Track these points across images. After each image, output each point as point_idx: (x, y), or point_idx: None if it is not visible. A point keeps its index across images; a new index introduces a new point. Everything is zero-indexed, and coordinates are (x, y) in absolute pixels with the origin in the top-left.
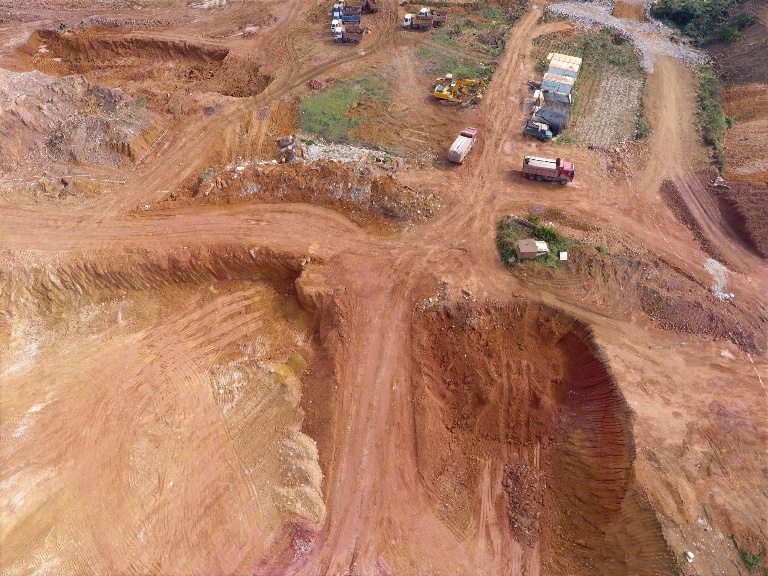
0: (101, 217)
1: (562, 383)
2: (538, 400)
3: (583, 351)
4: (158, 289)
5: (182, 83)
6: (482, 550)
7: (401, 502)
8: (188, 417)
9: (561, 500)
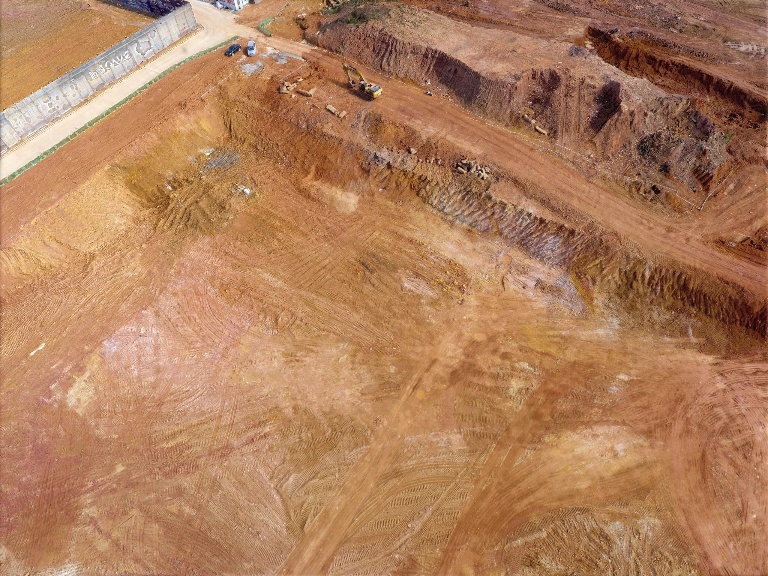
0: (688, 235)
1: None
2: None
3: None
4: (727, 324)
5: (721, 122)
6: None
7: None
8: (765, 462)
9: None
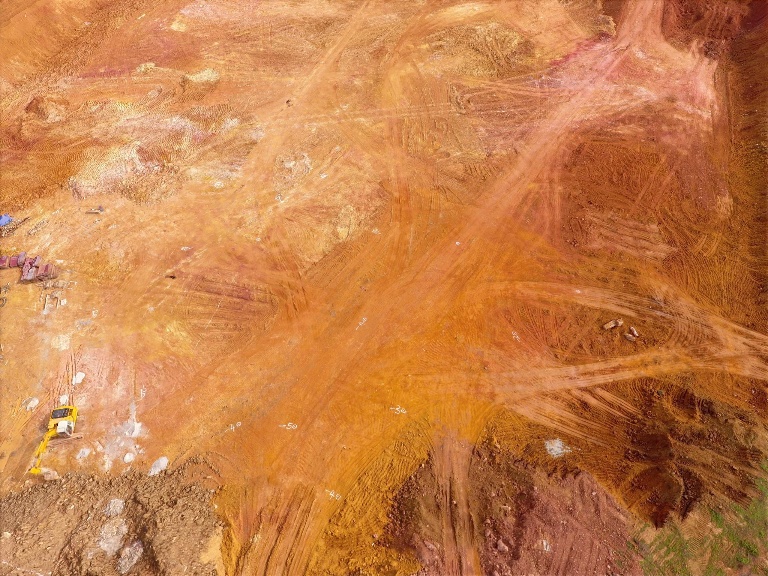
0: None
1: (745, 18)
2: (731, 19)
3: (762, 5)
4: None
5: None
6: (690, 56)
7: (652, 38)
8: (546, 4)
9: (733, 53)
